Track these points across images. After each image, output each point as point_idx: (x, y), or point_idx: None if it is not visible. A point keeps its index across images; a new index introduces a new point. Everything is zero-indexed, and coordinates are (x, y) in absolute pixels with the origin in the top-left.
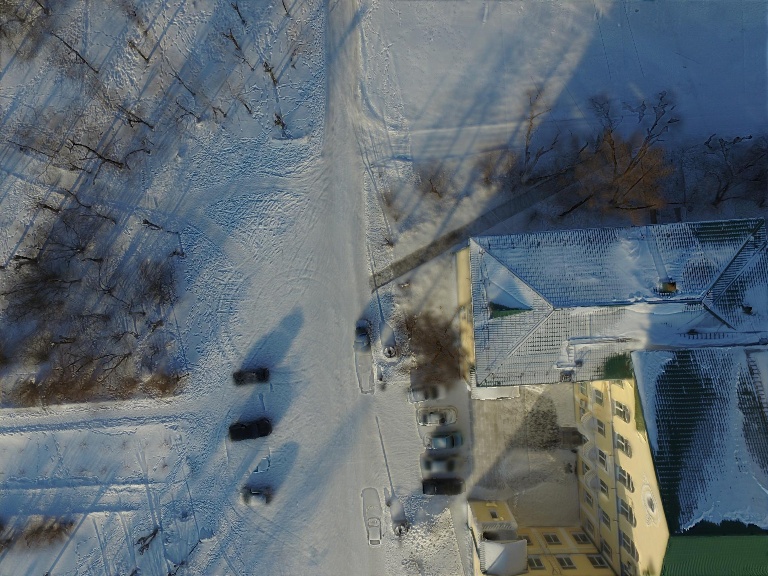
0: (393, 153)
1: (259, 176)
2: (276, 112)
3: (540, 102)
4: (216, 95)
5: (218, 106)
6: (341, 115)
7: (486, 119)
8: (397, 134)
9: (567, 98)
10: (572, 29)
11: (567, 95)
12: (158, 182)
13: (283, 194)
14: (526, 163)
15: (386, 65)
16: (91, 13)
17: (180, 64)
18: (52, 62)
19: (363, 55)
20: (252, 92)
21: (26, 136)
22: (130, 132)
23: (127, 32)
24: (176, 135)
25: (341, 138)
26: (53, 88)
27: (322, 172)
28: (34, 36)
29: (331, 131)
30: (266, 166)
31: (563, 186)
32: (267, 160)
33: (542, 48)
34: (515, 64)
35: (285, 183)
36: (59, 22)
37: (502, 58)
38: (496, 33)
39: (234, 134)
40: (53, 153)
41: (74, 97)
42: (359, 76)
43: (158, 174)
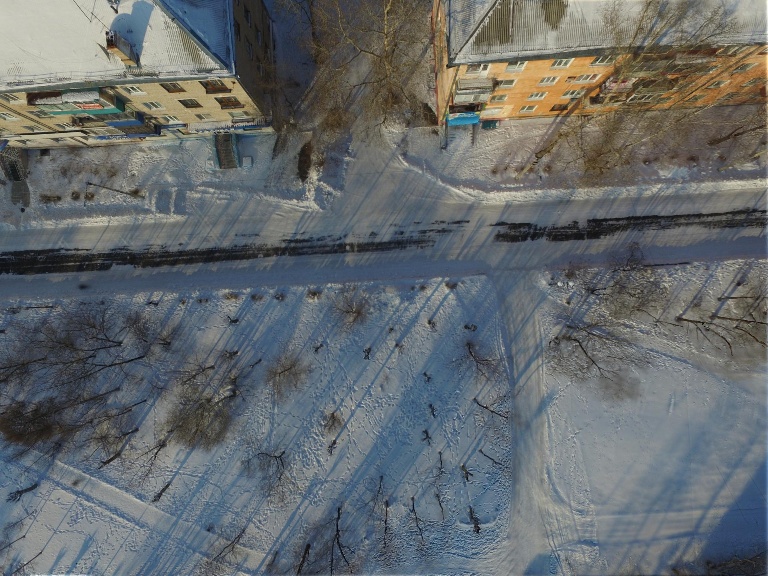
0: (579, 537)
1: (445, 557)
2: (463, 495)
3: (726, 491)
4: (403, 478)
5: (405, 489)
6: (527, 498)
7: (672, 506)
8: (583, 518)
9: (753, 488)
10: (757, 421)
11: (753, 485)
12: (345, 563)
13: (469, 575)
14: (720, 567)
15: (573, 451)
16: (279, 395)
17: (367, 446)
18: (239, 442)
19: (550, 440)
20: (440, 476)
21: (212, 514)
22: (316, 512)
23: (314, 413)
24: (364, 517)
25: (527, 520)
26: (240, 469)
27: (508, 553)
28: (222, 417)
29: (517, 513)
30: (452, 547)
31: (749, 573)
32: (454, 542)
33: (728, 439)
34: (701, 454)
35: (471, 564)
36: (247, 404)
37: (689, 449)
38: (682, 424)
39: (421, 516)
40: (239, 532)
41: (261, 477)
42: (545, 460)
43: (345, 555)
